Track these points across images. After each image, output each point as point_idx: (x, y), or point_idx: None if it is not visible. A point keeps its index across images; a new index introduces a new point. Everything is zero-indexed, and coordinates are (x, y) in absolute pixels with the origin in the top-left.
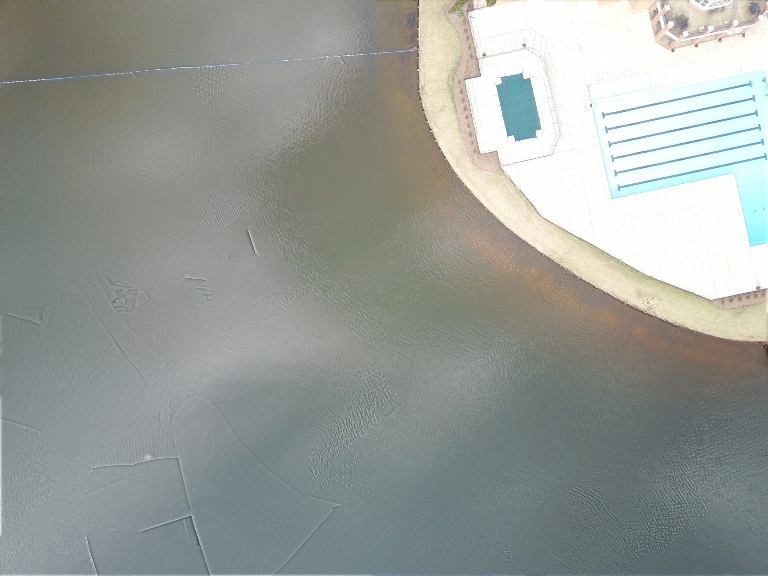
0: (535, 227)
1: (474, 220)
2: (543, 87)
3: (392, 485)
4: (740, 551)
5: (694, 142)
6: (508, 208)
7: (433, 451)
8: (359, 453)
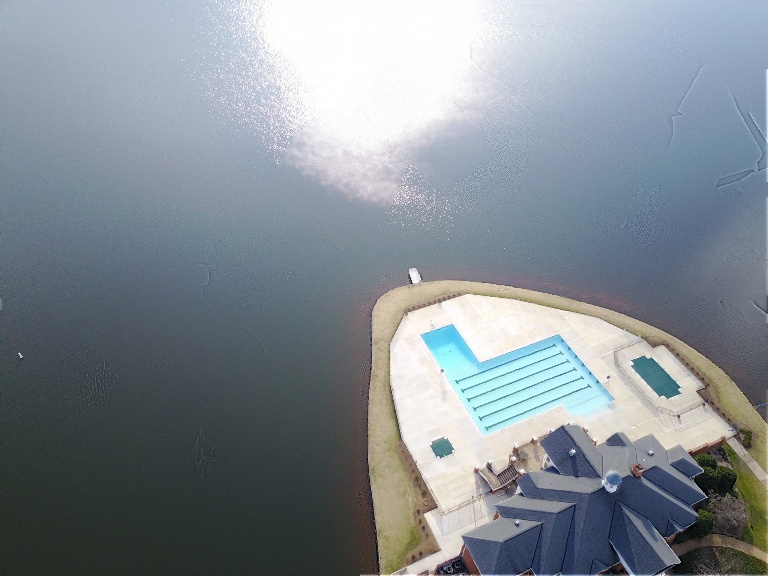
0: (600, 313)
1: (640, 314)
2: (646, 393)
3: (618, 180)
4: (439, 170)
5: (514, 382)
6: (624, 320)
7: (598, 205)
8: (637, 198)
